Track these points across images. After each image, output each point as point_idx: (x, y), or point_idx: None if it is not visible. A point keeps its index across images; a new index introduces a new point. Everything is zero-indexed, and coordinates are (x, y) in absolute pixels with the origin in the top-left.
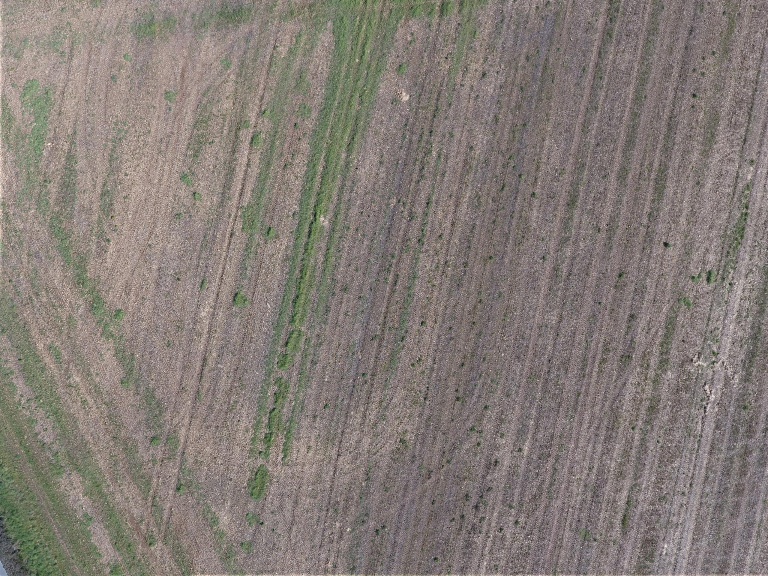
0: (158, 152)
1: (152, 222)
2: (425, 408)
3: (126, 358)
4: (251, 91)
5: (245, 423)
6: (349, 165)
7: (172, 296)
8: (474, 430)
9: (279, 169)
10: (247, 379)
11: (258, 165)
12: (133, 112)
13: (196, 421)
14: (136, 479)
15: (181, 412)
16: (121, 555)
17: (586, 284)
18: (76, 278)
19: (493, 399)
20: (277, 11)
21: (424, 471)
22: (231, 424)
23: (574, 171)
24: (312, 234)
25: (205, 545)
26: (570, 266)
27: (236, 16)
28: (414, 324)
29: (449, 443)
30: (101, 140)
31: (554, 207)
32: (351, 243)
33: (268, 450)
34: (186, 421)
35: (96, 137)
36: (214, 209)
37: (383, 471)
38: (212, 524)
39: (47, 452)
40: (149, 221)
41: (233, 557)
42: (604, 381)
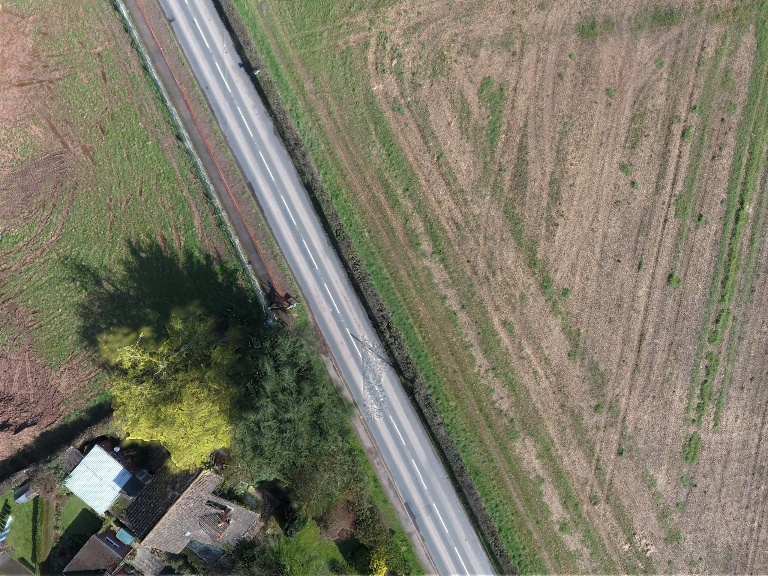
0: (600, 144)
1: (594, 208)
2: None
3: (573, 333)
4: (682, 88)
5: (679, 393)
6: None
7: (613, 276)
8: None
9: (707, 160)
10: (681, 353)
11: (688, 157)
12: (578, 107)
13: (635, 391)
14: (582, 444)
15: (622, 383)
16: (569, 513)
17: None
18: (528, 259)
19: None
20: (704, 15)
21: None
22: (666, 394)
23: None
24: (740, 220)
25: (643, 505)
26: None
27: (668, 19)
28: None
29: None
30: (550, 133)
31: None
32: None
33: (701, 418)
34: (626, 391)
35: (545, 130)
36: (649, 197)
37: None
38: (650, 486)
39: (504, 418)
40: (592, 207)
41: (669, 516)
42: None
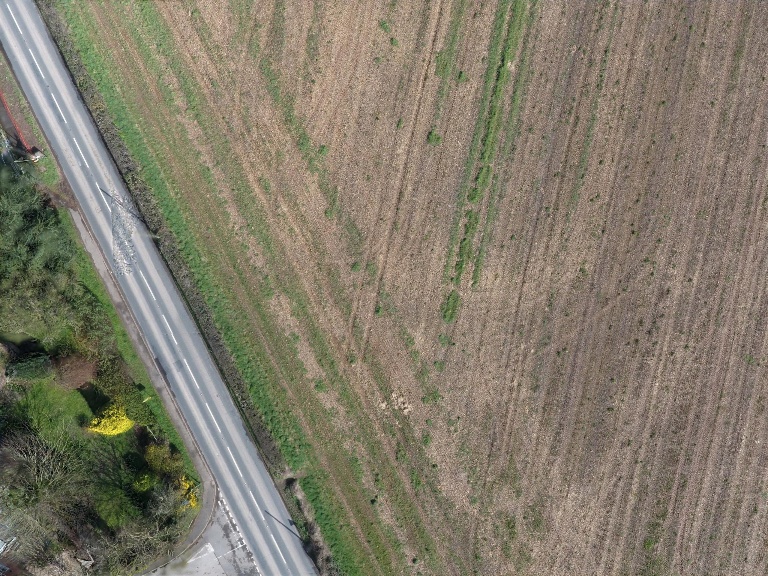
0: (358, 0)
1: (353, 65)
2: (603, 240)
3: (329, 190)
4: None
5: (438, 252)
6: (534, 14)
7: (371, 134)
8: (648, 261)
9: (469, 18)
10: (440, 211)
11: (450, 14)
12: None
13: (393, 249)
14: (338, 302)
15: (379, 241)
16: (325, 371)
17: (751, 128)
18: (284, 116)
19: (665, 233)
20: None
21: (602, 298)
22: (425, 252)
23: (740, 23)
24: (500, 77)
25: (401, 363)
26: (736, 111)
27: None
28: (593, 163)
29: (625, 273)
30: None
31: (722, 56)
32: (535, 87)
33: (459, 277)
34: (384, 249)
35: None
36: (409, 54)
37: (564, 298)
38: (408, 344)
39: (258, 275)
40: (350, 64)
41: (427, 375)
42: (767, 218)
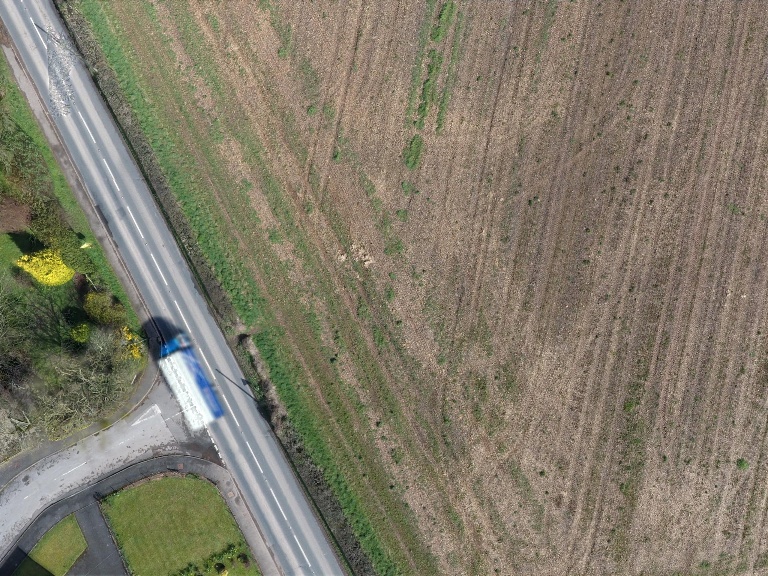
0: None
1: None
2: (576, 82)
3: (283, 28)
4: None
5: (400, 94)
6: None
7: None
8: (624, 104)
9: None
10: (401, 50)
11: None
12: None
13: (352, 91)
14: (293, 147)
15: (337, 82)
16: (279, 221)
17: None
18: None
19: (642, 74)
20: None
21: (575, 144)
22: (386, 95)
23: None
24: None
25: (361, 213)
26: None
27: None
28: None
29: (599, 117)
30: None
31: None
32: None
33: (423, 120)
34: (342, 91)
35: None
36: None
37: (535, 143)
38: (368, 192)
39: (207, 118)
40: None
41: (389, 225)
42: (750, 59)
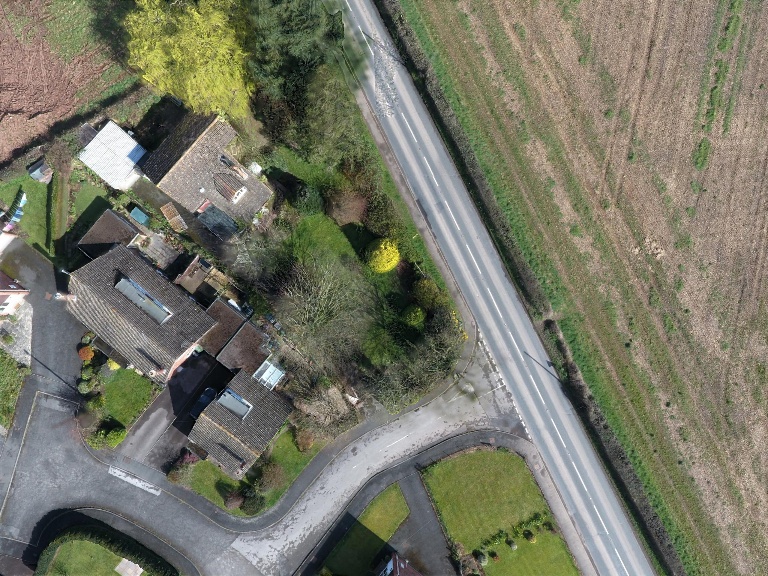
0: None
1: None
2: None
3: (583, 38)
4: None
5: (689, 100)
6: None
7: None
8: None
9: None
10: (691, 60)
11: None
12: None
13: (646, 97)
14: (593, 148)
15: (632, 88)
16: (579, 216)
17: None
18: None
19: None
20: None
21: None
22: (676, 100)
23: None
24: None
25: (654, 209)
26: None
27: None
28: None
29: None
30: None
31: None
32: None
33: (710, 124)
34: (636, 97)
35: None
36: None
37: None
38: (661, 190)
39: (515, 120)
40: None
41: (679, 220)
42: None
